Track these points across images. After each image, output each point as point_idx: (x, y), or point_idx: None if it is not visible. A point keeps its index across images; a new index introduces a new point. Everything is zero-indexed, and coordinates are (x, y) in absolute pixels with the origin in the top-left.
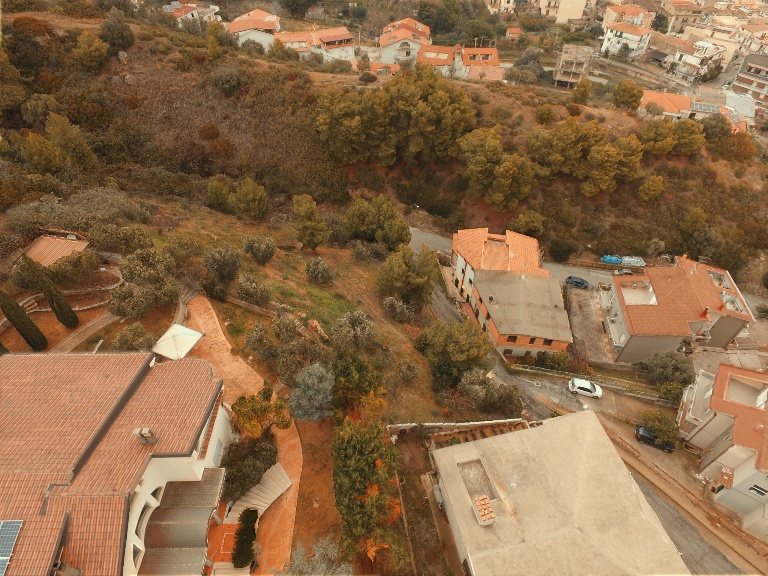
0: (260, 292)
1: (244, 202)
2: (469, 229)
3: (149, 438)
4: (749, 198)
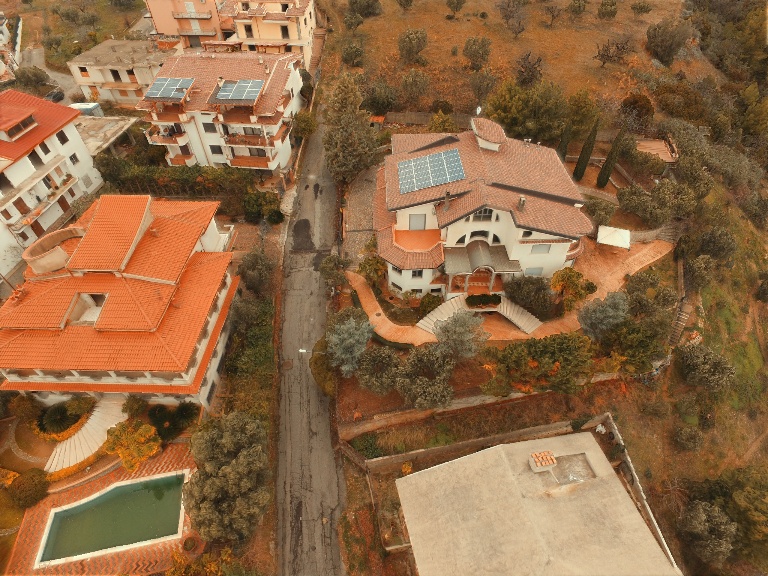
0: (698, 274)
1: None
2: None
3: (520, 205)
4: None
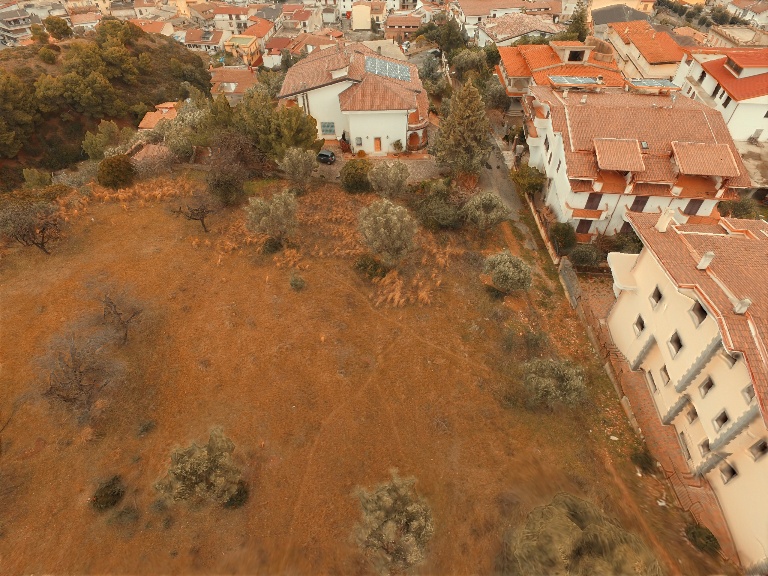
0: None
1: None
2: (142, 121)
3: None
4: (170, 49)
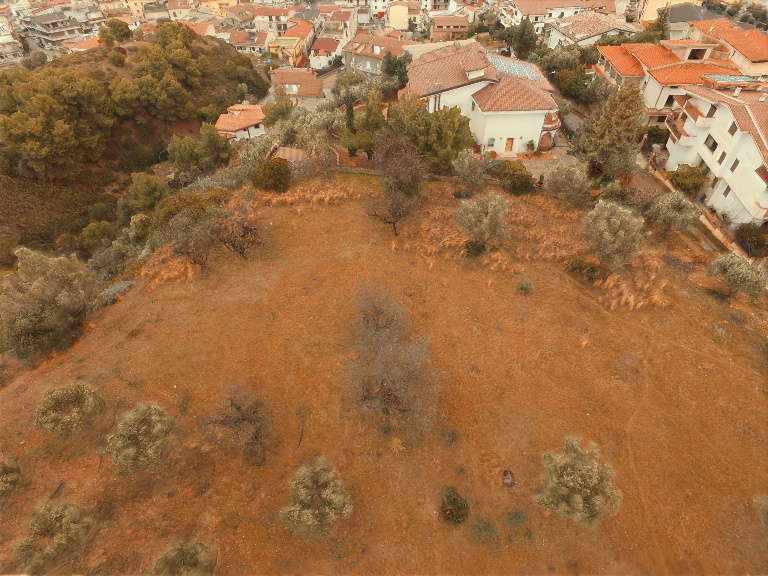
0: None
1: (149, 195)
2: (216, 123)
3: None
4: (222, 51)
